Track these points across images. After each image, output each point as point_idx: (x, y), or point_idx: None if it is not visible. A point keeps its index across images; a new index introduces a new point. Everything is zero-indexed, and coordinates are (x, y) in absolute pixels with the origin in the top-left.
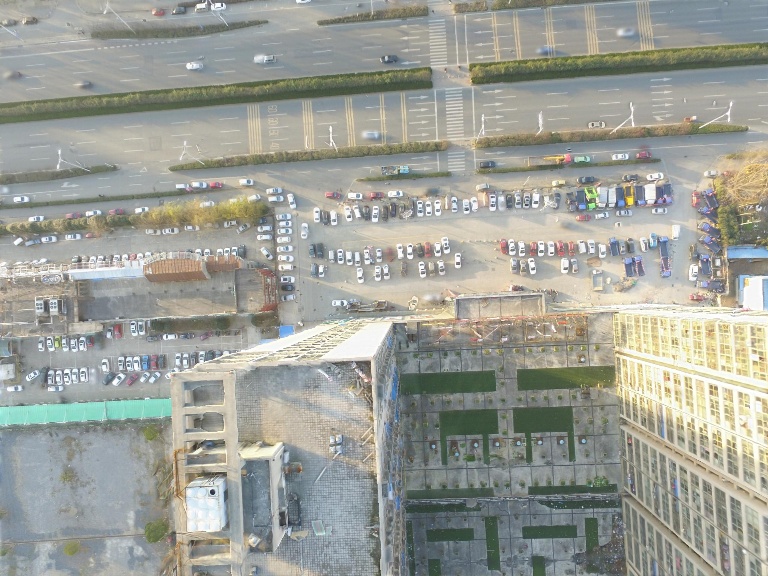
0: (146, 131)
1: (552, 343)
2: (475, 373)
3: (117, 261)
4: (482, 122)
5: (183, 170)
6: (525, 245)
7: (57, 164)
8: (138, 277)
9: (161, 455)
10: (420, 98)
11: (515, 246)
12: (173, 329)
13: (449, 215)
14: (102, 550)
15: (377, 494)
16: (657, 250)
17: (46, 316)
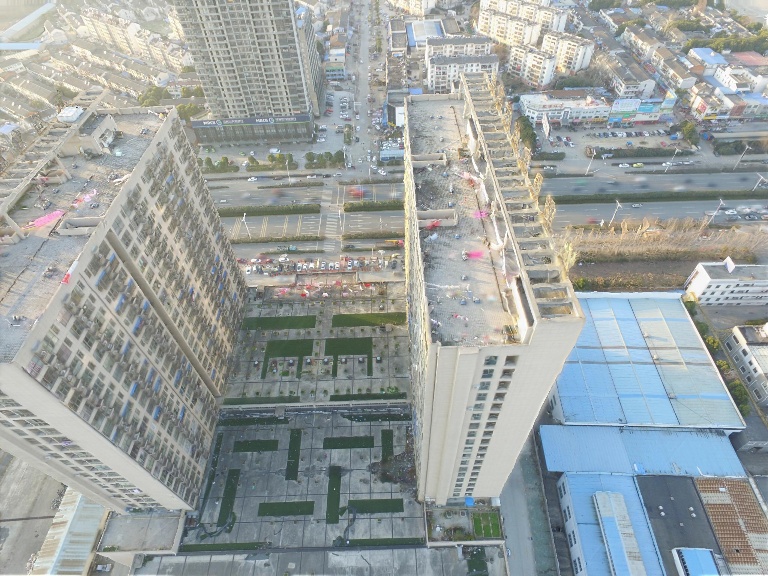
0: None
1: (361, 299)
2: (301, 317)
3: None
4: (339, 212)
5: None
6: None
7: None
8: None
9: None
10: (311, 218)
11: None
12: None
13: None
14: None
15: None
16: None
17: None
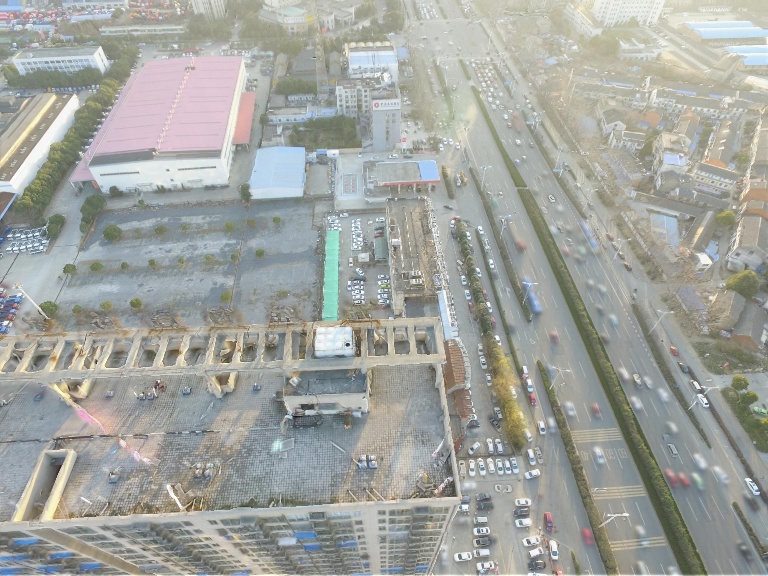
0: (567, 343)
1: None
2: None
3: None
4: None
5: (540, 372)
6: None
7: (526, 282)
8: None
9: None
10: None
11: None
12: None
13: None
14: None
15: None
16: None
17: (409, 277)
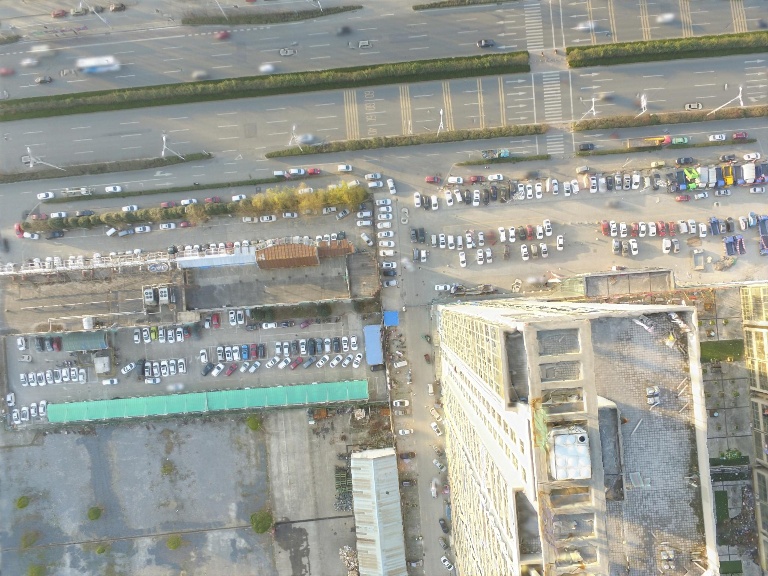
0: (240, 118)
1: None
2: None
3: (226, 248)
4: (593, 103)
5: (280, 157)
6: (626, 226)
7: None
8: (245, 264)
9: (262, 445)
10: (518, 82)
11: (616, 227)
12: (274, 317)
13: (549, 198)
14: (203, 544)
15: (694, 444)
16: (756, 229)
17: (154, 305)
